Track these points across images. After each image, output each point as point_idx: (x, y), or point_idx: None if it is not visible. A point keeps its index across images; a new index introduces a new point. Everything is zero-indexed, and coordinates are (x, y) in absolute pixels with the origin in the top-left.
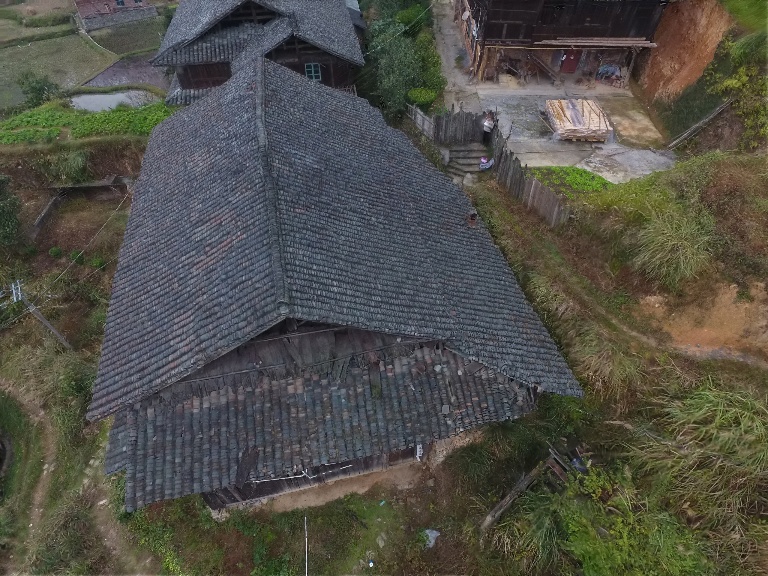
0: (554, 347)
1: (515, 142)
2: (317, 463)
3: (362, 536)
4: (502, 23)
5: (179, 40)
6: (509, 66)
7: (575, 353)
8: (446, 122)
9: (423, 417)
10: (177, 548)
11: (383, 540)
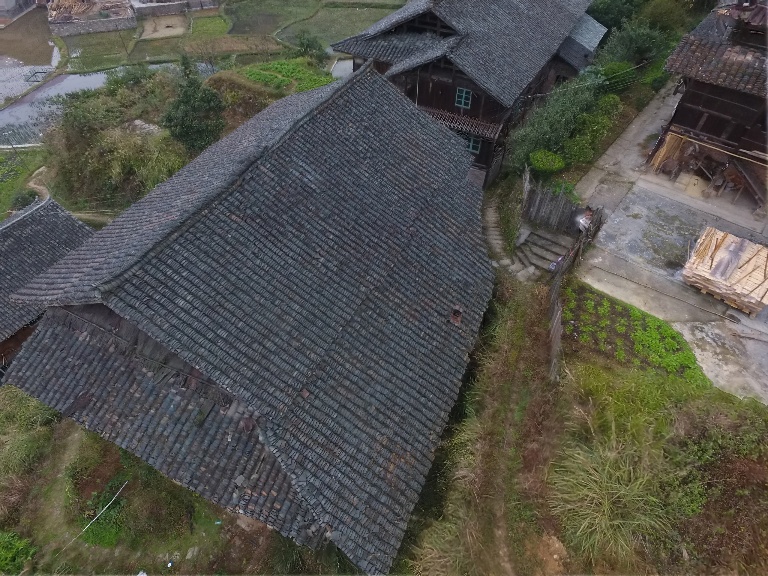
0: (409, 506)
1: (620, 258)
2: (118, 443)
3: (184, 536)
4: (701, 111)
5: (363, 33)
6: (702, 167)
7: (431, 531)
8: (541, 199)
9: (218, 472)
10: (87, 434)
11: (192, 554)
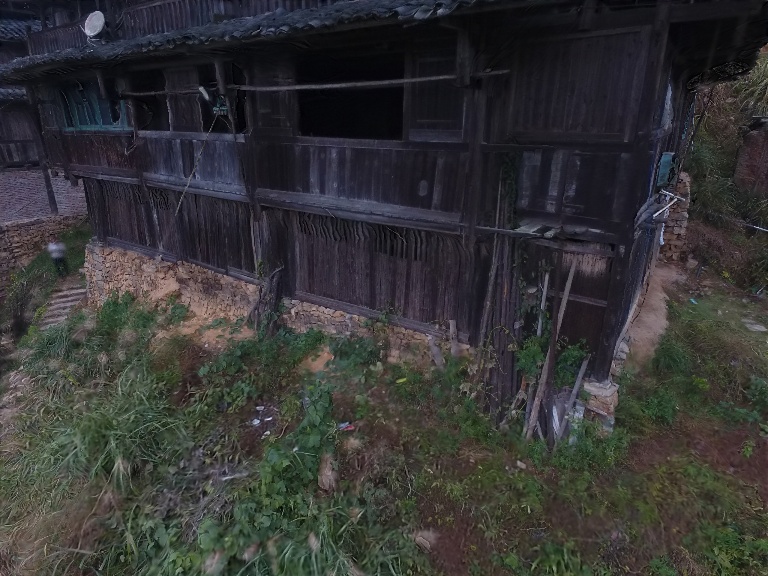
0: None
1: None
2: None
3: None
4: None
5: None
6: None
7: None
8: None
9: None
10: (614, 567)
11: (755, 324)
